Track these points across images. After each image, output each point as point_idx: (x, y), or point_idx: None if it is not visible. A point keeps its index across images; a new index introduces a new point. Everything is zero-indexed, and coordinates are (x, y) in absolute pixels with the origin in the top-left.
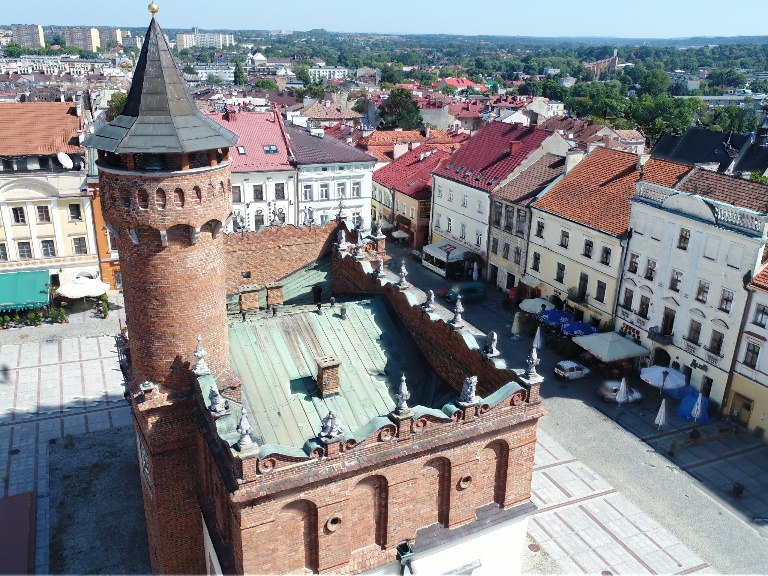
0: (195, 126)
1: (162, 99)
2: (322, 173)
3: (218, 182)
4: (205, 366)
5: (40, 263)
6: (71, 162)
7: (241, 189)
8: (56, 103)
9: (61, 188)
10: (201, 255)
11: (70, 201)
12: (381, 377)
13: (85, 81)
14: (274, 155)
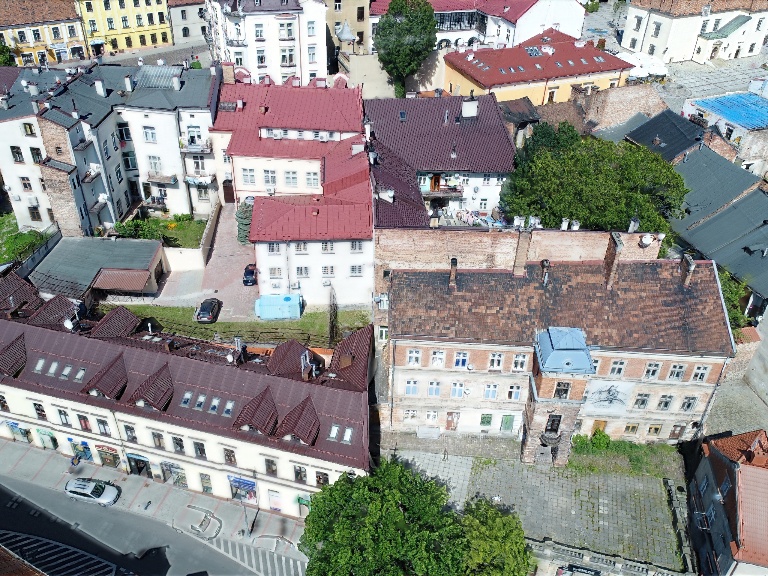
0: None
1: None
2: None
3: None
4: None
5: None
6: None
7: None
8: None
9: None
10: None
11: None
12: None
13: None
14: None
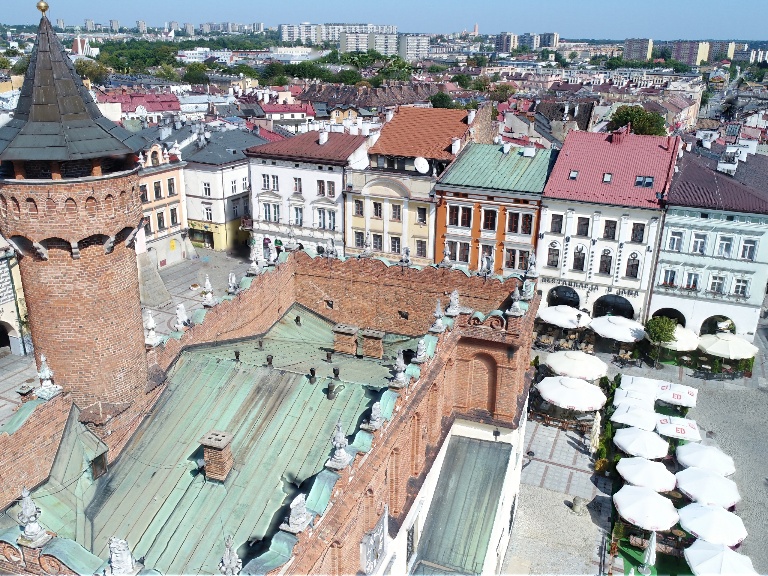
0: (45, 134)
1: (29, 102)
2: (700, 220)
3: (63, 198)
4: (47, 389)
5: (387, 256)
6: (428, 167)
7: (590, 222)
8: (458, 110)
9: (414, 191)
10: (56, 273)
11: (419, 204)
12: (290, 488)
13: (634, 93)
14: (644, 188)
